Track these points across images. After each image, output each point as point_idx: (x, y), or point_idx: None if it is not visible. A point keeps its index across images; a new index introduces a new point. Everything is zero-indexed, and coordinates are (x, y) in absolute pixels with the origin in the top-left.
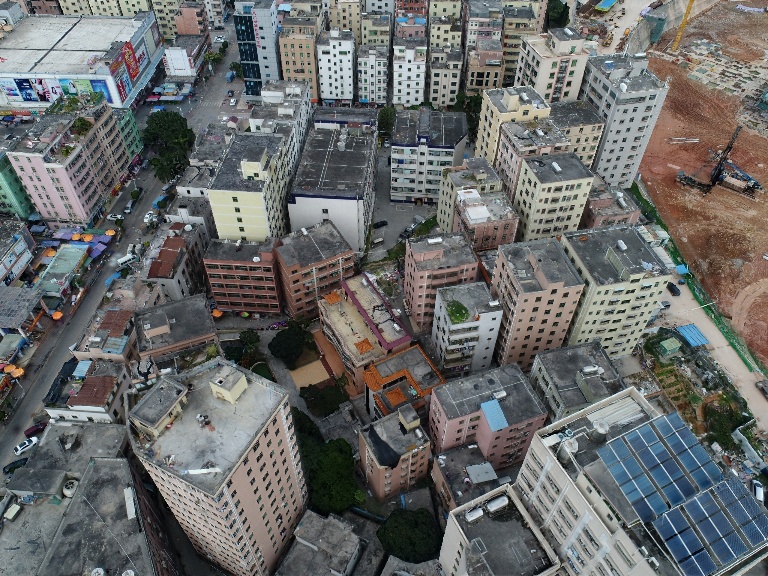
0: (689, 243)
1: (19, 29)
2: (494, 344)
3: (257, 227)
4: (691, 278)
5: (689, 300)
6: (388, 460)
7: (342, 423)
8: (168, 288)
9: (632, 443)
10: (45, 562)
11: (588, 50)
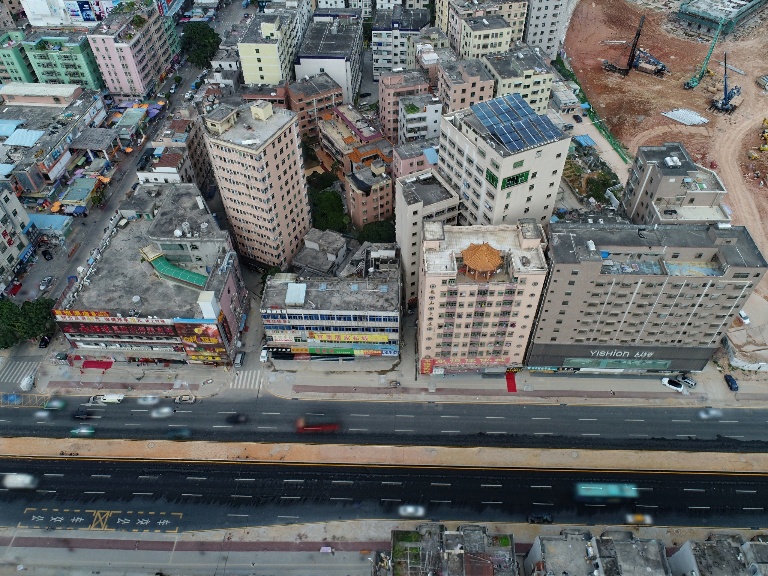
0: (606, 108)
1: None
2: None
3: (273, 75)
4: (592, 112)
5: (589, 125)
6: (363, 188)
7: None
8: None
9: (490, 104)
10: (152, 226)
11: None
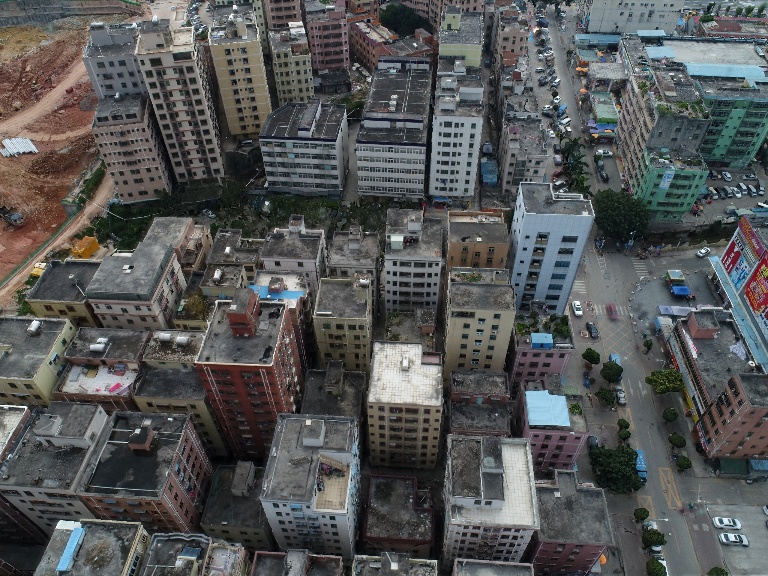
0: None
1: None
2: None
3: None
4: None
5: None
6: None
7: None
8: None
9: None
10: None
11: None
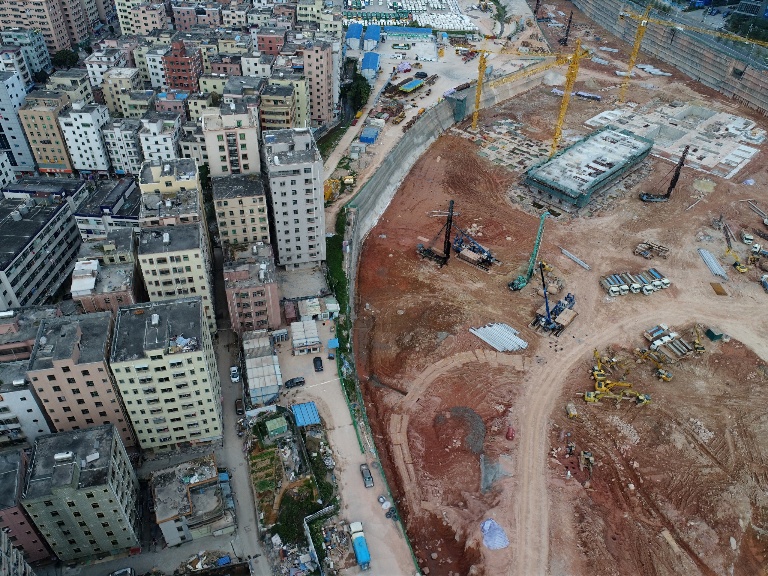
0: (404, 316)
1: None
2: (47, 426)
3: None
4: (344, 352)
5: (331, 376)
6: None
7: None
8: None
9: None
10: None
11: (371, 127)
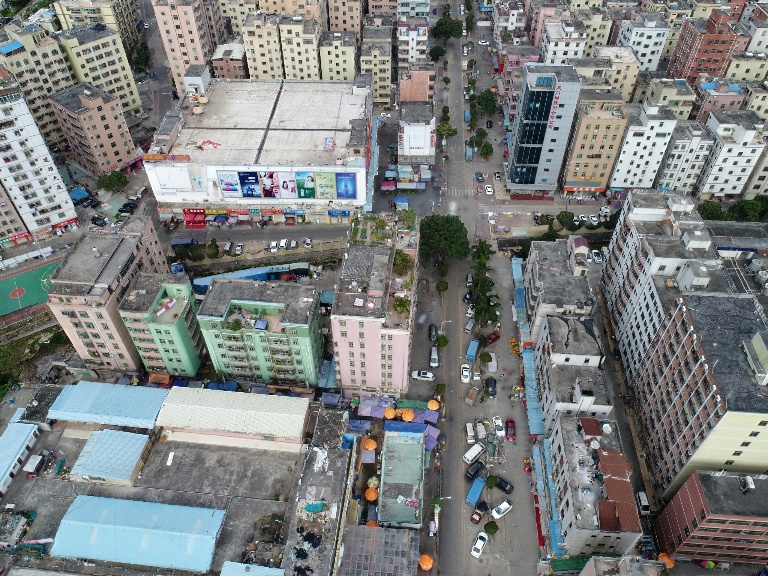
0: None
1: (214, 100)
2: None
3: (766, 452)
4: None
5: None
6: None
7: None
8: (623, 541)
9: None
10: None
11: None
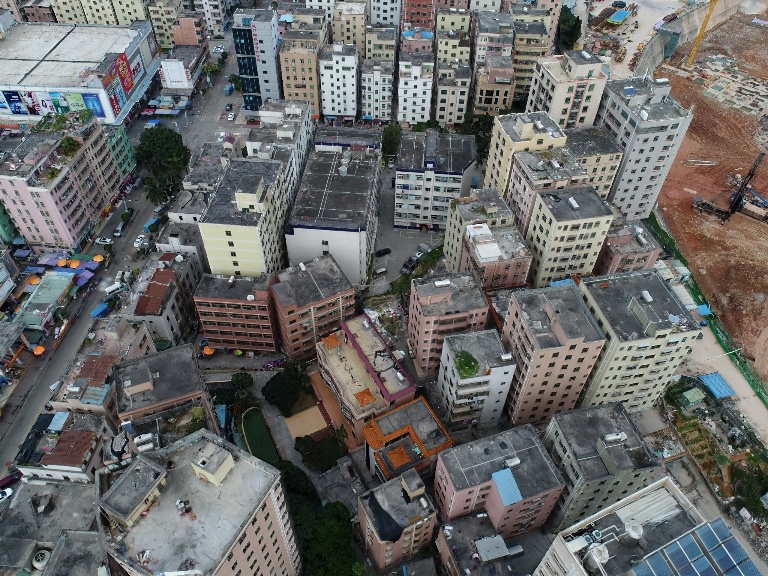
0: (708, 275)
1: (10, 37)
2: (505, 397)
3: (252, 262)
4: (713, 319)
5: (712, 344)
6: (390, 534)
7: (340, 480)
8: (156, 325)
9: (672, 558)
10: None
11: None
